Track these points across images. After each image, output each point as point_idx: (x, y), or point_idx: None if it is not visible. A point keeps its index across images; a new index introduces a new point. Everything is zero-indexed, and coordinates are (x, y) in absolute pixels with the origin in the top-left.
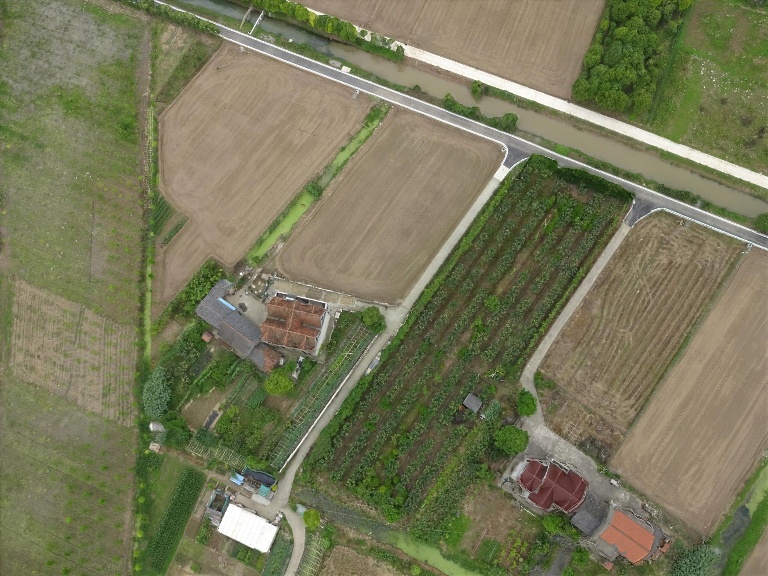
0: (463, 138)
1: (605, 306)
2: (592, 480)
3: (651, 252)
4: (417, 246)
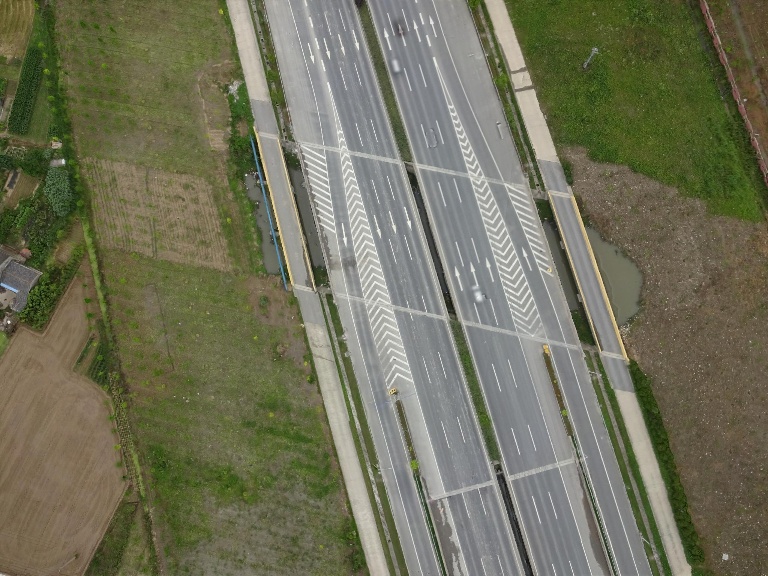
0: None
1: None
2: None
3: None
4: None
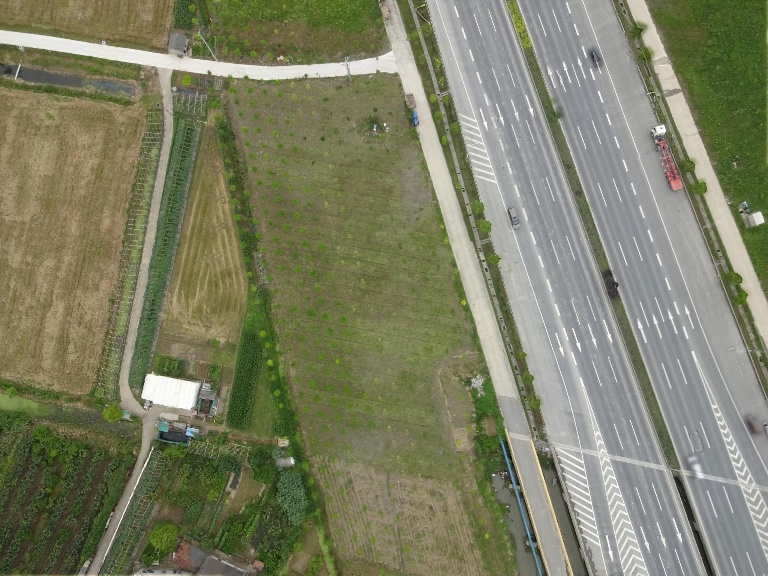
0: None
1: None
2: None
3: None
4: None
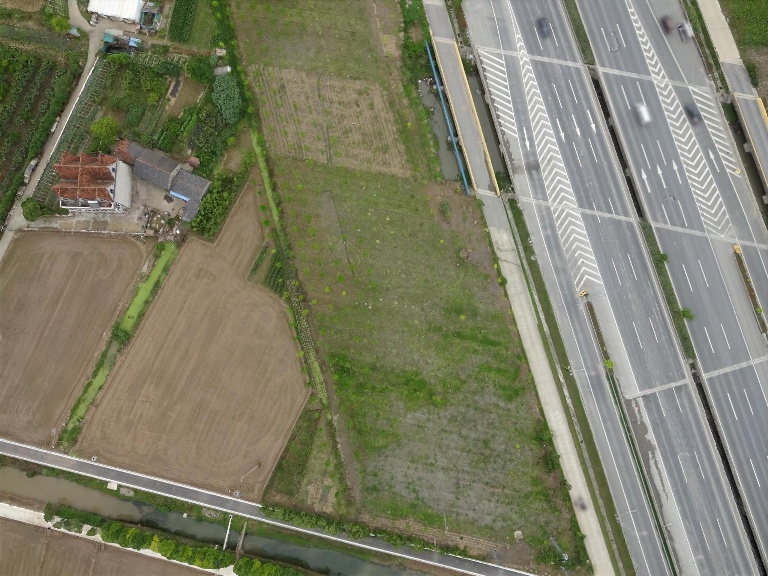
0: None
1: None
2: None
3: None
4: (8, 295)
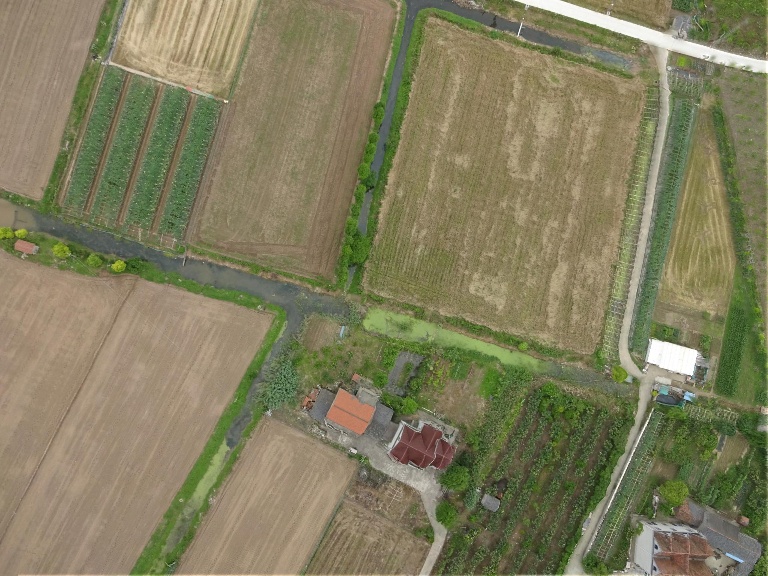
0: None
1: None
2: (373, 449)
3: None
4: None
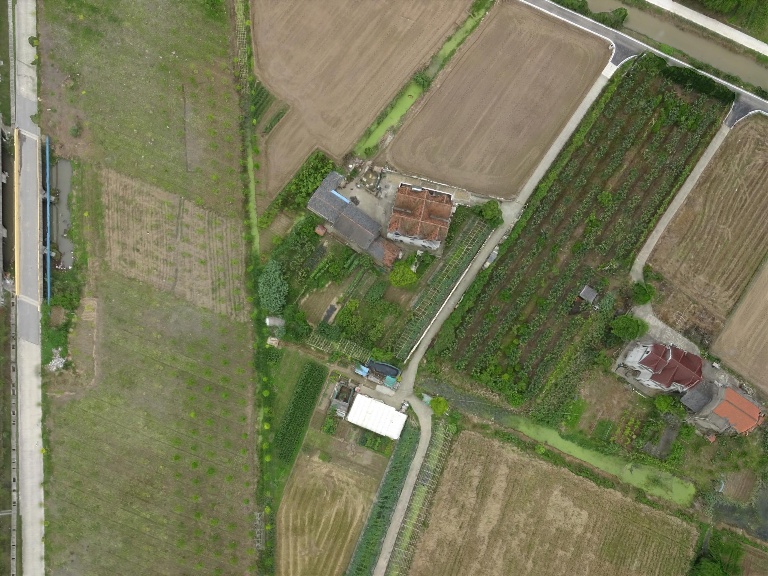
0: (571, 33)
1: (707, 203)
2: None
3: (748, 153)
4: (529, 142)
